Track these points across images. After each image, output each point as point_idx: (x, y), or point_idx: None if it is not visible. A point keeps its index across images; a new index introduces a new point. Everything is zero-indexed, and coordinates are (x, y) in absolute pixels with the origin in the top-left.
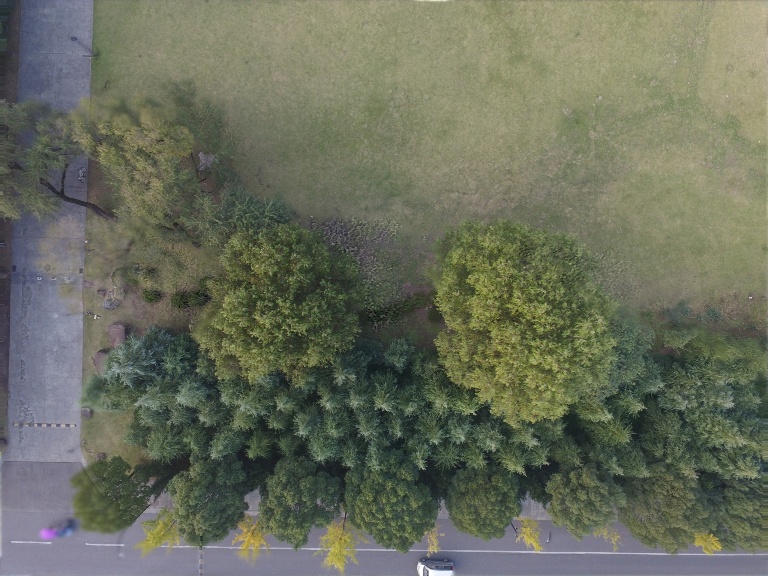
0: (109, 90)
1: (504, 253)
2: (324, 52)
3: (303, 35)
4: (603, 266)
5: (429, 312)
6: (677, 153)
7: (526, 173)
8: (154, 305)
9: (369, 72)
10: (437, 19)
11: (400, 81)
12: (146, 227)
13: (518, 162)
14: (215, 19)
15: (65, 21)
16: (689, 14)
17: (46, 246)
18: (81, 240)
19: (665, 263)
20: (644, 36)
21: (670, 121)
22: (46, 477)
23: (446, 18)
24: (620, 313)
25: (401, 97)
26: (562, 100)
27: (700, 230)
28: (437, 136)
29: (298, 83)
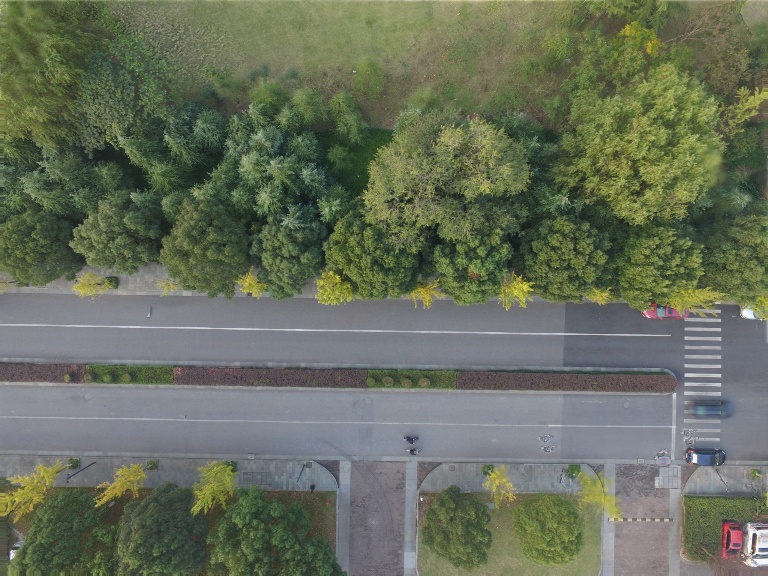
0: None
1: (108, 31)
2: None
3: None
4: (205, 41)
5: (33, 89)
6: None
7: None
8: None
9: None
10: None
11: None
12: None
13: None
14: None
15: None
16: None
17: None
18: None
19: (267, 38)
20: None
21: None
22: None
23: None
24: (222, 88)
25: None
26: None
27: (301, 4)
28: None
29: None
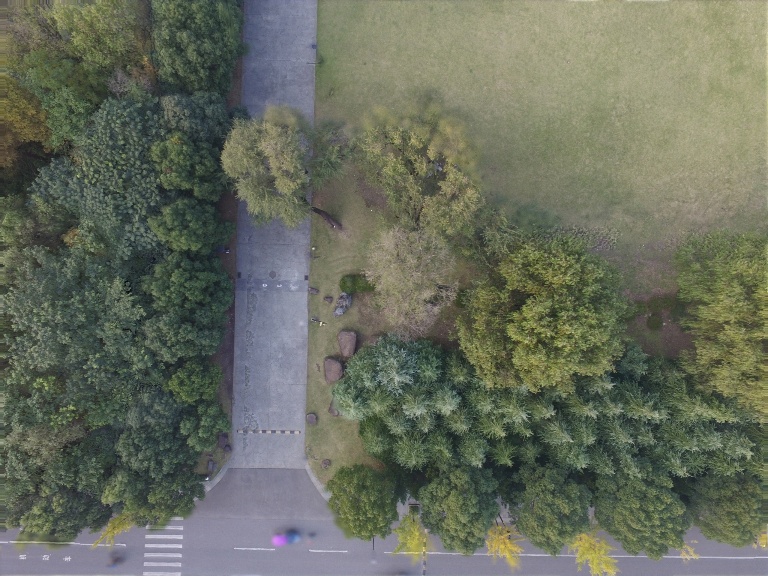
0: (334, 97)
1: (721, 261)
2: (547, 61)
3: (527, 44)
4: None
5: (649, 319)
6: None
7: (745, 182)
8: (380, 312)
9: (592, 81)
10: (658, 29)
11: (622, 90)
12: (371, 234)
13: (737, 171)
14: (440, 27)
15: (289, 28)
16: None
17: (271, 253)
18: (306, 247)
19: None
20: None
21: None
22: (270, 484)
23: (667, 28)
24: None
25: (623, 106)
26: None
27: None
28: (658, 145)
29: (522, 92)
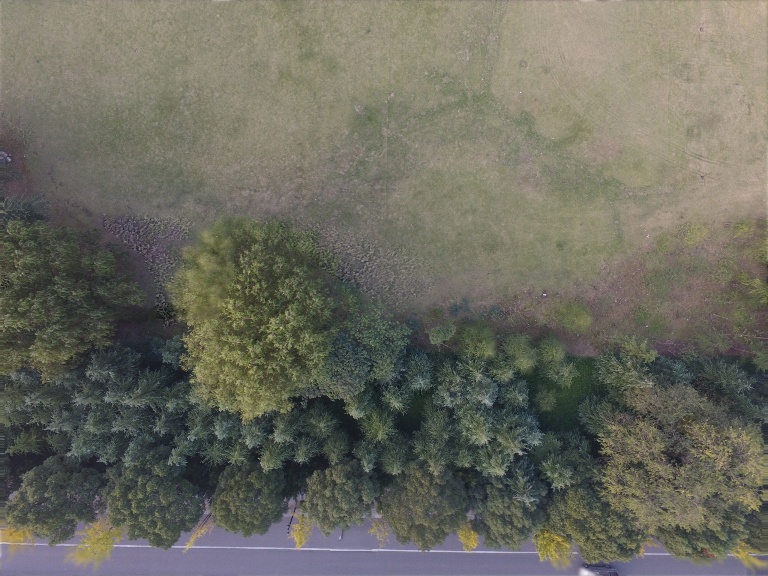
0: None
1: (297, 250)
2: (115, 50)
3: (94, 34)
4: (395, 263)
5: (221, 309)
6: (470, 150)
7: (317, 170)
8: None
9: (159, 70)
10: (227, 17)
11: (191, 79)
12: None
13: (309, 159)
14: (7, 18)
15: None
16: (482, 10)
17: None
18: None
19: (458, 260)
20: (435, 33)
21: (464, 118)
22: None
23: (236, 16)
24: (413, 310)
25: (192, 95)
26: (354, 97)
27: (492, 227)
28: (228, 134)
29: (89, 81)
